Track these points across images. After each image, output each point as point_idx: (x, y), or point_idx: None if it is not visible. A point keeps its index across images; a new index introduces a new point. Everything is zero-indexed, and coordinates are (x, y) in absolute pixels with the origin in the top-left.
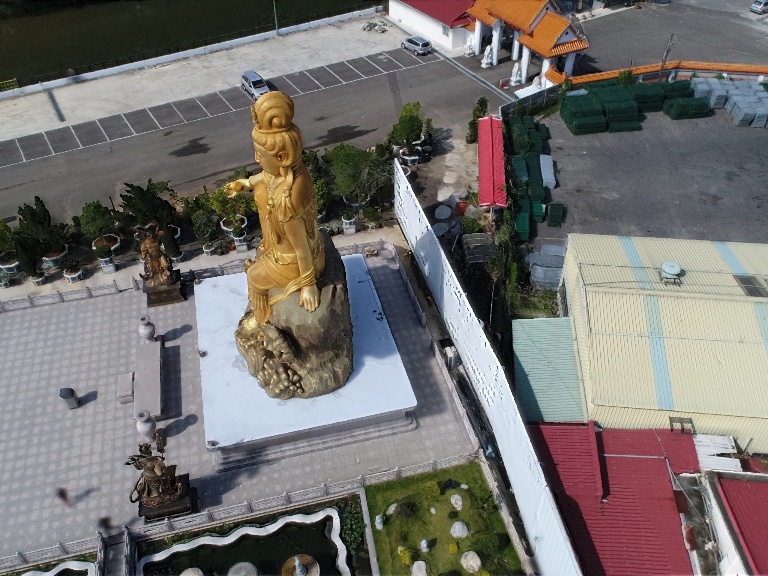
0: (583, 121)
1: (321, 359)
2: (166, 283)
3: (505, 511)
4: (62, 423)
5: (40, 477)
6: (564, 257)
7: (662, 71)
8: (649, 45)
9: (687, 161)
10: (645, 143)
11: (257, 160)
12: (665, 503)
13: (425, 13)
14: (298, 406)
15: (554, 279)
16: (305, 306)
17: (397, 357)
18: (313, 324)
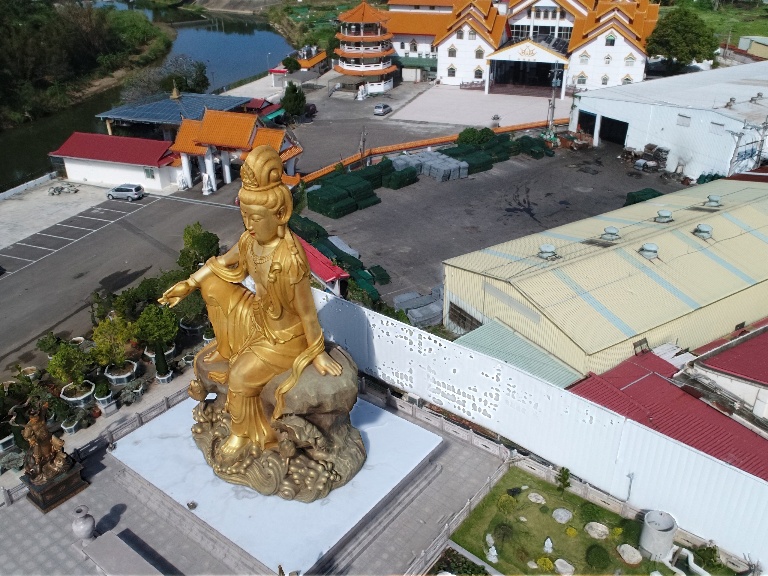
0: (339, 205)
1: (342, 436)
2: (63, 470)
3: (575, 483)
4: None
5: None
6: (444, 285)
7: (362, 159)
8: (326, 150)
9: (432, 212)
10: (393, 209)
11: (250, 227)
12: (684, 399)
13: (121, 162)
14: (343, 496)
15: (431, 314)
16: (331, 372)
17: (387, 414)
18: (349, 386)
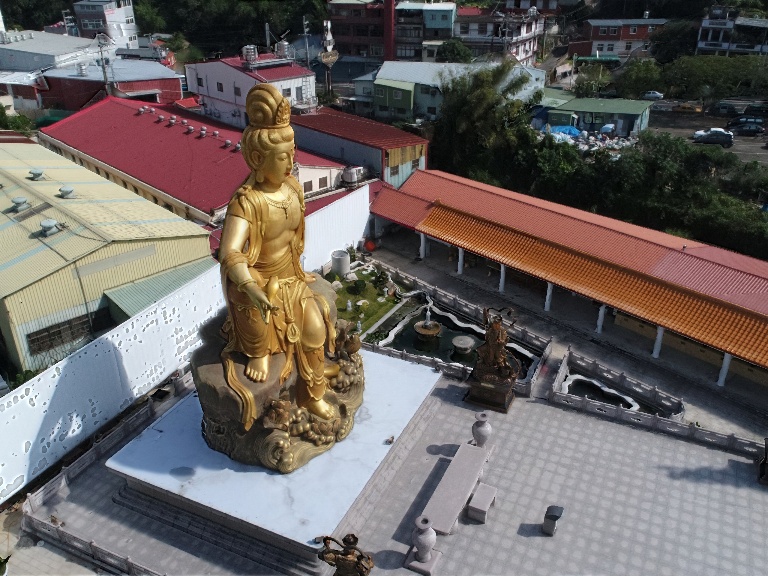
0: None
1: None
2: None
3: None
4: (569, 516)
5: (600, 474)
6: None
7: None
8: None
9: None
10: None
11: None
12: None
13: None
14: None
15: None
16: None
17: None
18: None
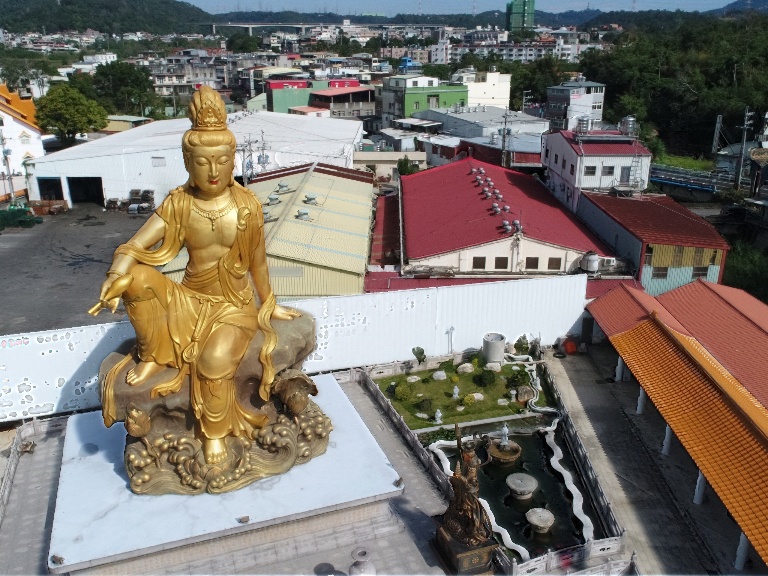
0: None
1: None
2: None
3: (417, 362)
4: None
5: None
6: None
7: None
8: None
9: None
10: None
11: (217, 173)
12: (423, 282)
13: None
14: (337, 434)
15: None
16: (296, 315)
17: None
18: None
